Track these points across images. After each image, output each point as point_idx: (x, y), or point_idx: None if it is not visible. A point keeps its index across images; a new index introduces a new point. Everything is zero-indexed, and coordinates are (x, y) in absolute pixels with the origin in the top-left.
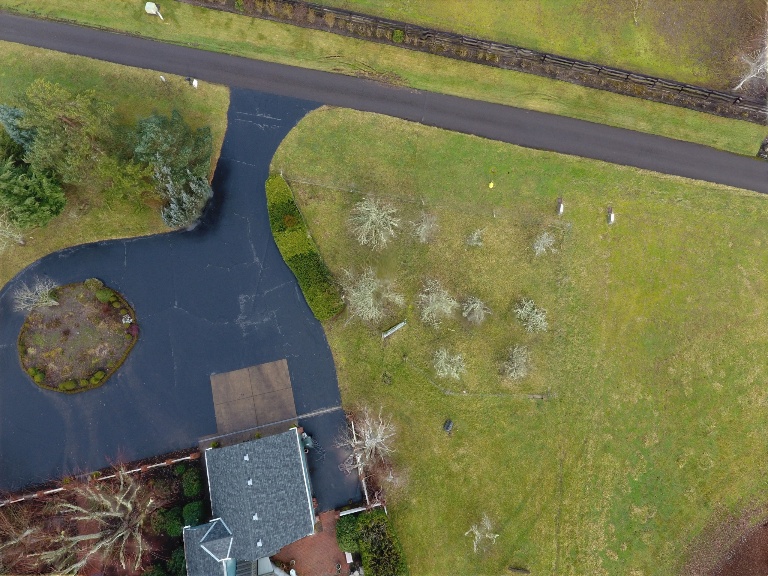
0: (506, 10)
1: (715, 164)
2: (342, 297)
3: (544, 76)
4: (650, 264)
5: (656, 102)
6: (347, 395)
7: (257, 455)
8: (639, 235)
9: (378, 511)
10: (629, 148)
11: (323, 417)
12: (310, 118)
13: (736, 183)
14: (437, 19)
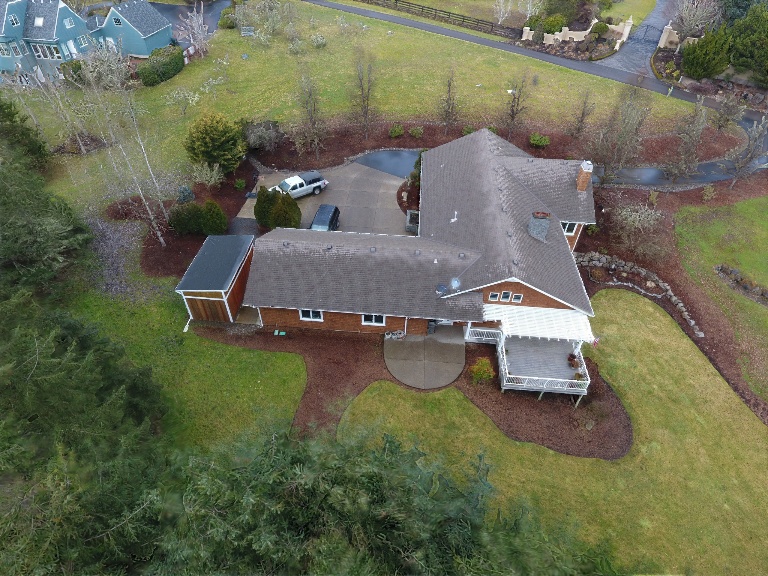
0: None
1: None
2: (233, 15)
3: None
4: (400, 47)
5: None
6: None
7: (146, 5)
8: None
9: None
10: None
11: None
12: None
13: (472, 41)
14: None
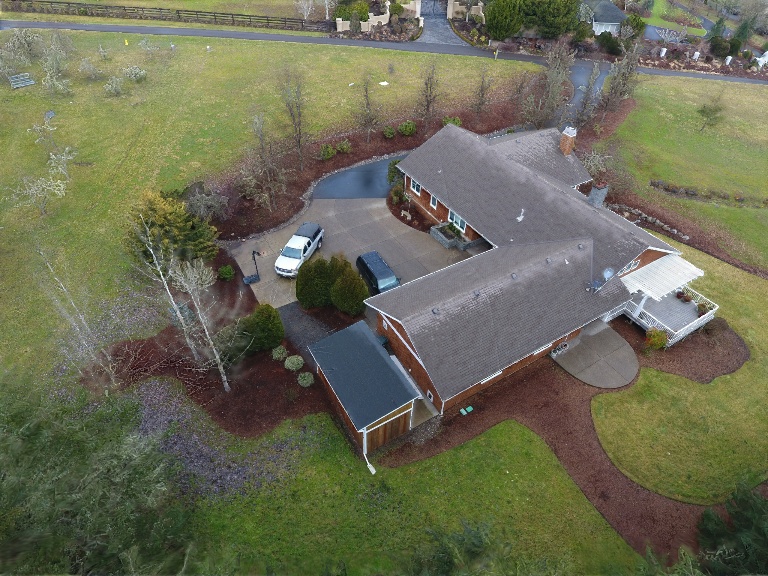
0: None
1: (286, 37)
2: None
3: None
4: (235, 62)
5: (253, 27)
6: None
7: None
8: None
9: None
10: (228, 34)
11: None
12: (4, 31)
13: (299, 41)
14: None
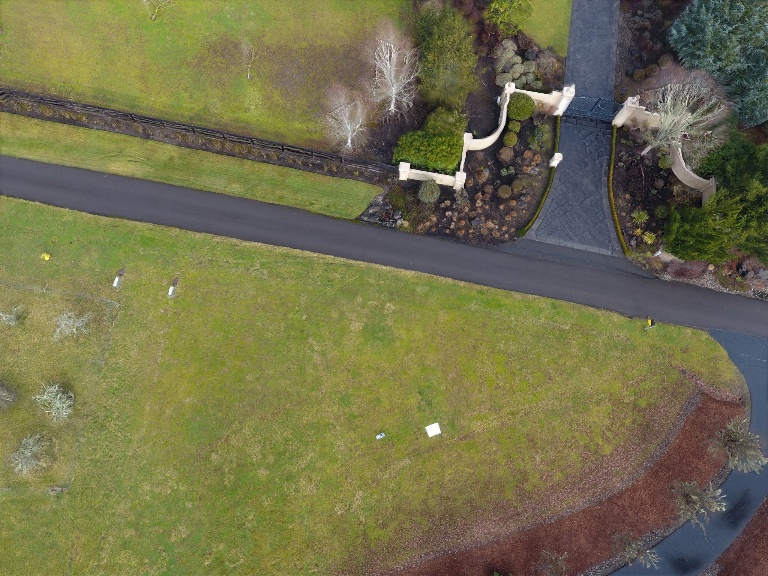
0: (107, 65)
1: (304, 229)
2: None
3: (137, 136)
4: (211, 340)
5: (257, 162)
6: None
7: None
8: (204, 308)
9: None
10: (210, 213)
11: None
12: None
13: (323, 249)
14: (30, 76)
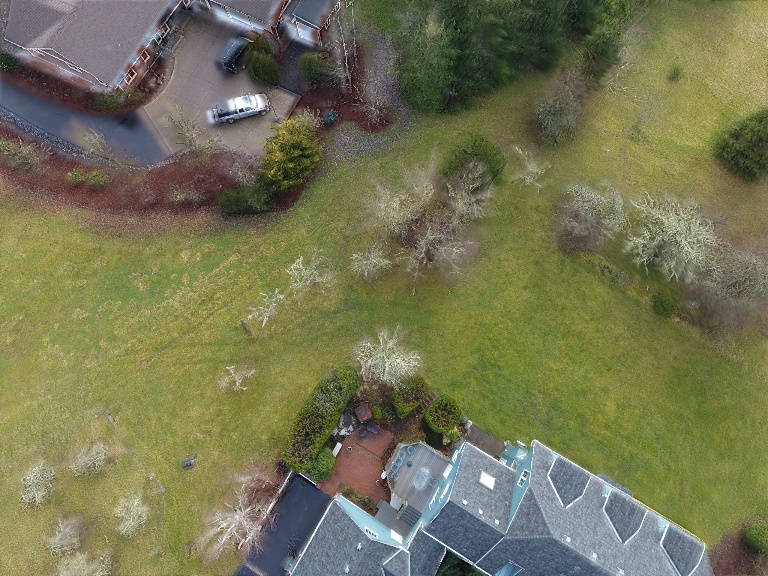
0: None
1: None
2: None
3: None
4: None
5: None
6: (232, 570)
7: None
8: None
9: (284, 464)
10: None
11: (266, 571)
12: None
13: None
14: None
